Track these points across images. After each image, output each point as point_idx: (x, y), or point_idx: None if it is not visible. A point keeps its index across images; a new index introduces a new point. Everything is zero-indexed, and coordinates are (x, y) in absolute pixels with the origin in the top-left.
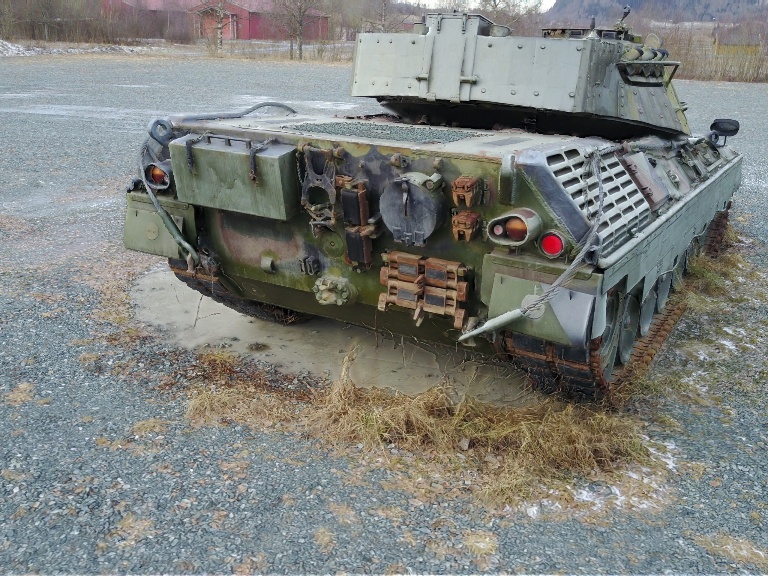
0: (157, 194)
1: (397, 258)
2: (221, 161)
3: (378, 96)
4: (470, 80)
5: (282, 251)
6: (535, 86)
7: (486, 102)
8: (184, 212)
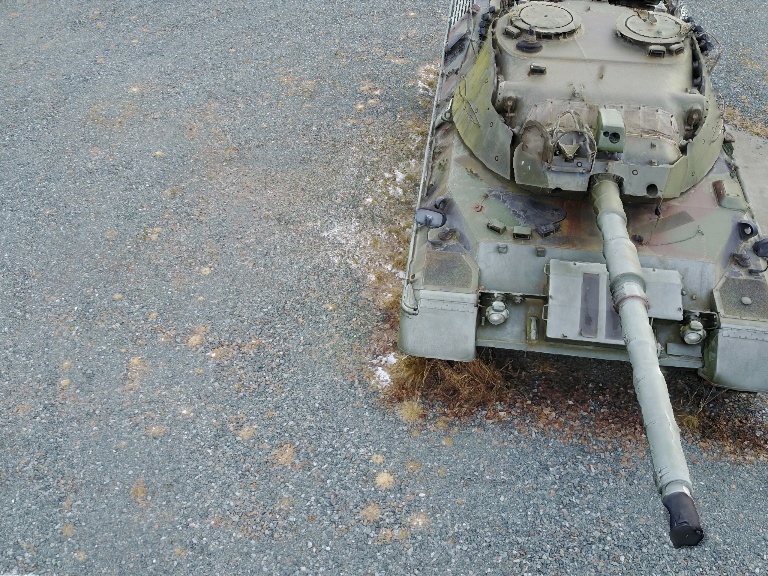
0: None
1: None
2: None
3: None
4: None
5: None
6: None
7: None
8: None
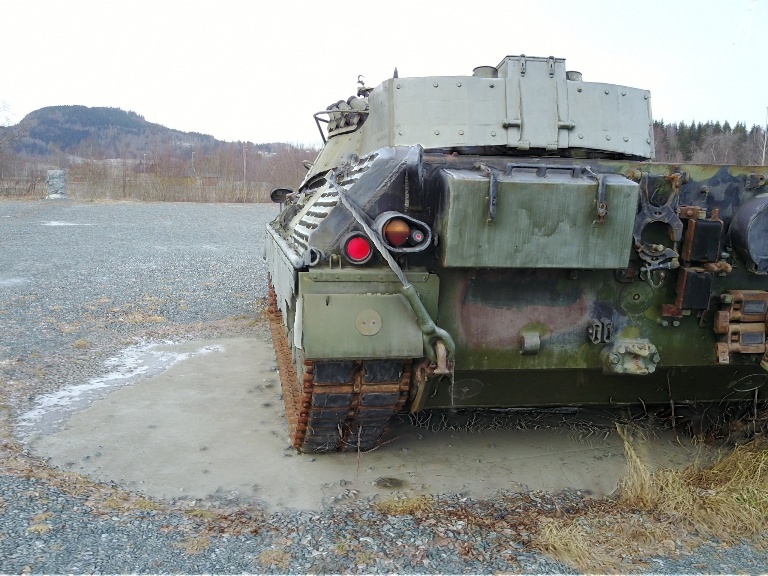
0: (363, 266)
1: (744, 296)
2: (544, 197)
3: (448, 147)
4: (570, 125)
5: (557, 320)
6: (624, 132)
7: (582, 149)
8: (421, 286)
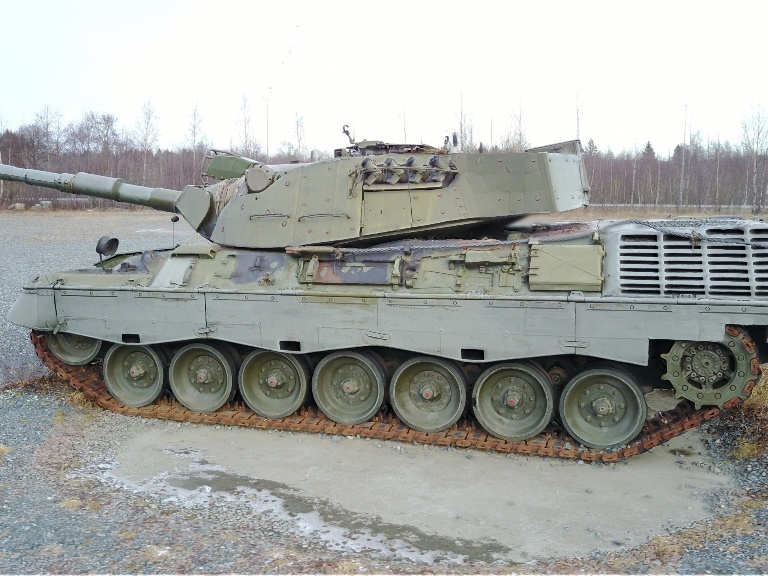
0: None
1: None
2: None
3: None
4: None
5: None
6: None
7: None
8: None
